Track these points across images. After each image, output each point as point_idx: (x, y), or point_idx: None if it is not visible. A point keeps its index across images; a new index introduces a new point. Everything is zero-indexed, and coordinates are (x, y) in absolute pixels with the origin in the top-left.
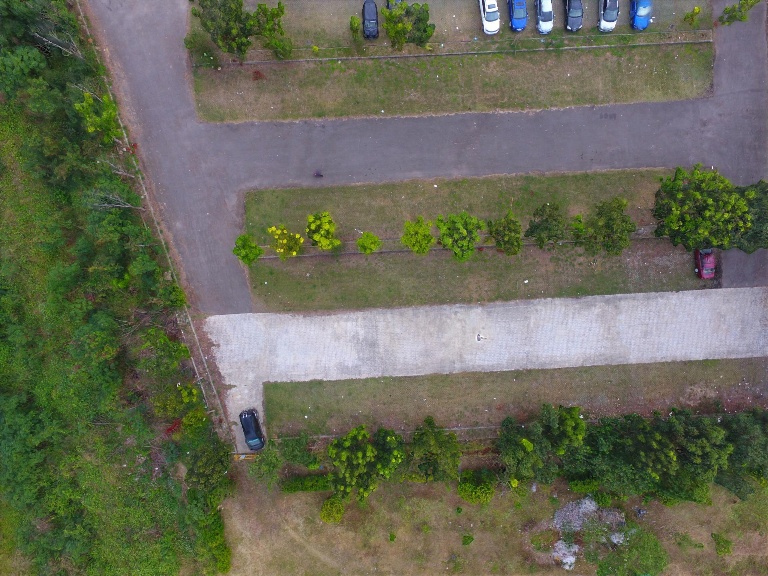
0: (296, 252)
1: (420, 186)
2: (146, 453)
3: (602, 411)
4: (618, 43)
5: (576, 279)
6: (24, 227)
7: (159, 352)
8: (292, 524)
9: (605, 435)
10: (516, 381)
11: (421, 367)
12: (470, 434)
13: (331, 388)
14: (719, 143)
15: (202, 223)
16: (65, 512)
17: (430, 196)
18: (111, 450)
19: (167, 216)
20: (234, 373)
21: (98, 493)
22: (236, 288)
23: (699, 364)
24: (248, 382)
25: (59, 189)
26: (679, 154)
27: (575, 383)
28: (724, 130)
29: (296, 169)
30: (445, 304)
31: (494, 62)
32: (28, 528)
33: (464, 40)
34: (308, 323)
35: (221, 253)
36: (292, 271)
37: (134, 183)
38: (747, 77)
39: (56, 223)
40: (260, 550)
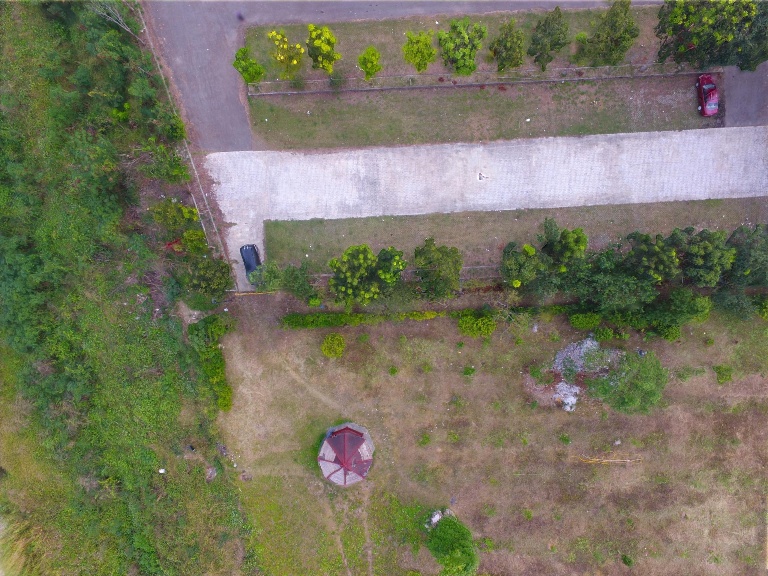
0: (297, 61)
1: (421, 23)
2: (147, 289)
3: (604, 251)
4: None
5: (578, 118)
6: (23, 61)
7: (159, 158)
8: (293, 365)
9: (607, 258)
10: (518, 221)
11: (422, 206)
12: (471, 273)
13: (332, 227)
14: None
15: (202, 59)
16: (66, 356)
17: None
18: (112, 287)
19: (167, 51)
20: (235, 211)
21: (99, 333)
22: (236, 125)
23: (702, 204)
24: (249, 220)
25: (58, 23)
26: None
27: (577, 223)
28: None
29: (296, 5)
30: (446, 143)
31: None
32: (29, 371)
33: None
34: (309, 161)
35: (221, 90)
36: (293, 108)
37: (133, 16)
38: None
39: (55, 51)
40: (261, 390)
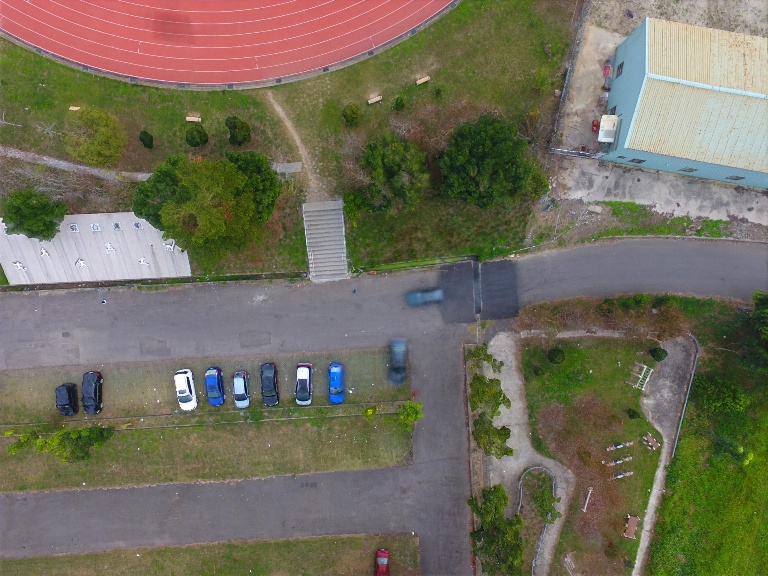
0: None
1: (123, 556)
2: None
3: None
4: (317, 415)
5: None
6: None
7: None
8: None
9: None
10: None
11: None
12: None
13: None
14: (419, 510)
15: None
16: None
17: (133, 565)
18: None
19: None
20: None
21: None
22: None
23: None
24: None
25: None
26: (380, 521)
27: None
28: (424, 497)
29: None
30: None
31: (195, 434)
32: None
33: (165, 413)
34: None
35: None
36: None
37: None
38: (446, 445)
39: None
40: None
